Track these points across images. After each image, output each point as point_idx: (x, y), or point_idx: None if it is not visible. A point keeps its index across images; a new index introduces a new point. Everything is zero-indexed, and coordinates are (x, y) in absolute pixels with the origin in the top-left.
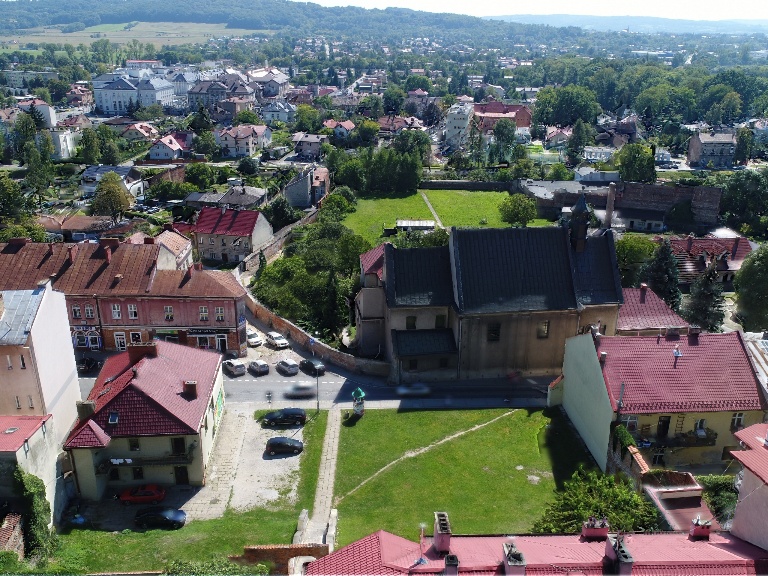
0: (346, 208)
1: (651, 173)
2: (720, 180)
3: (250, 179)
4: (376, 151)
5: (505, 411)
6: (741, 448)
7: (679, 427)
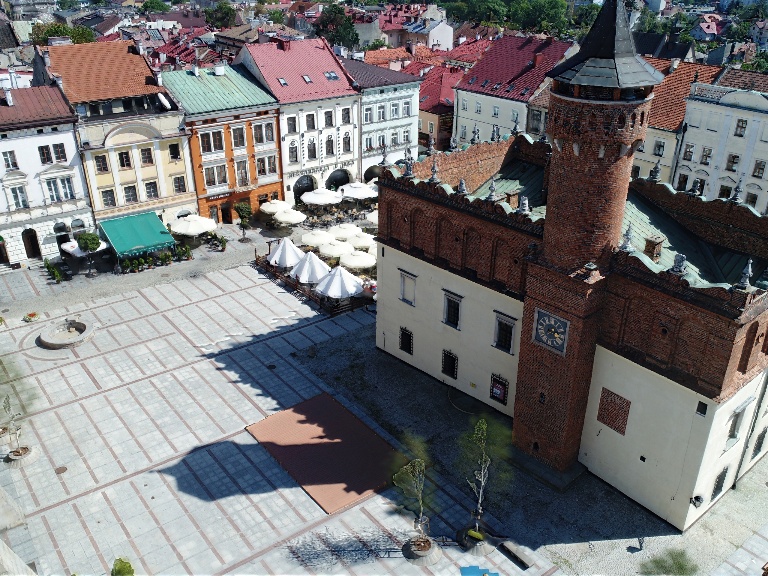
0: None
1: None
2: None
3: None
4: None
5: None
6: None
7: None
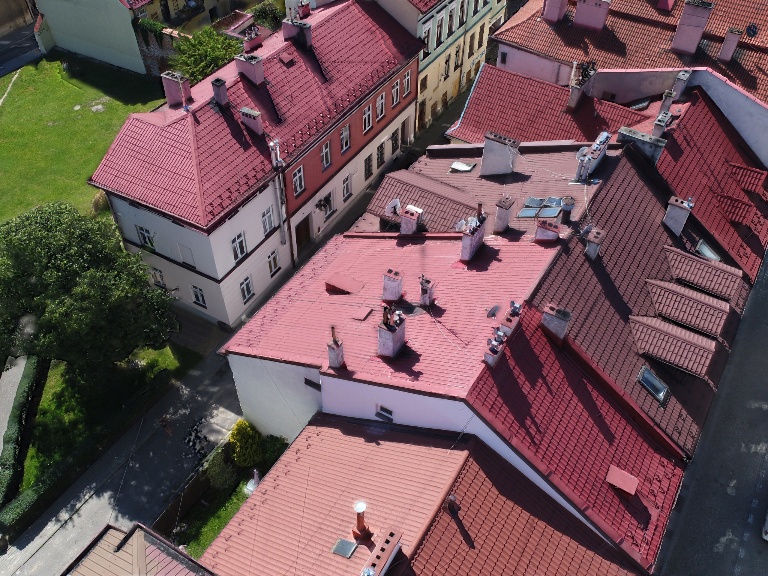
0: None
1: None
2: None
3: None
4: None
5: (10, 76)
6: (219, 6)
7: (176, 5)
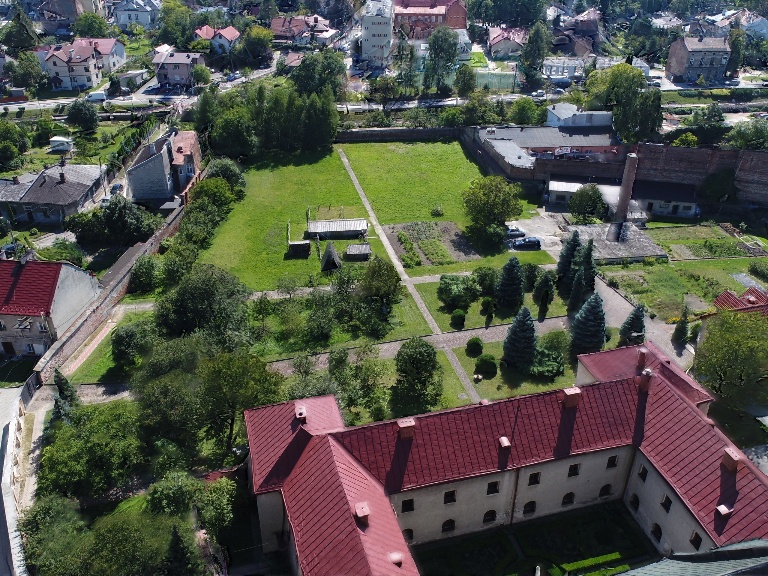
0: (228, 199)
1: (656, 114)
2: (758, 128)
3: (81, 143)
4: (269, 93)
5: None
6: None
7: None
